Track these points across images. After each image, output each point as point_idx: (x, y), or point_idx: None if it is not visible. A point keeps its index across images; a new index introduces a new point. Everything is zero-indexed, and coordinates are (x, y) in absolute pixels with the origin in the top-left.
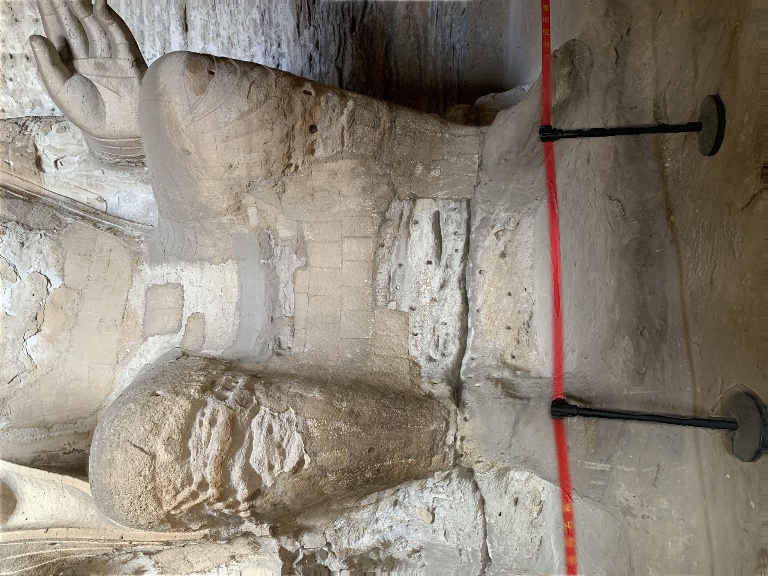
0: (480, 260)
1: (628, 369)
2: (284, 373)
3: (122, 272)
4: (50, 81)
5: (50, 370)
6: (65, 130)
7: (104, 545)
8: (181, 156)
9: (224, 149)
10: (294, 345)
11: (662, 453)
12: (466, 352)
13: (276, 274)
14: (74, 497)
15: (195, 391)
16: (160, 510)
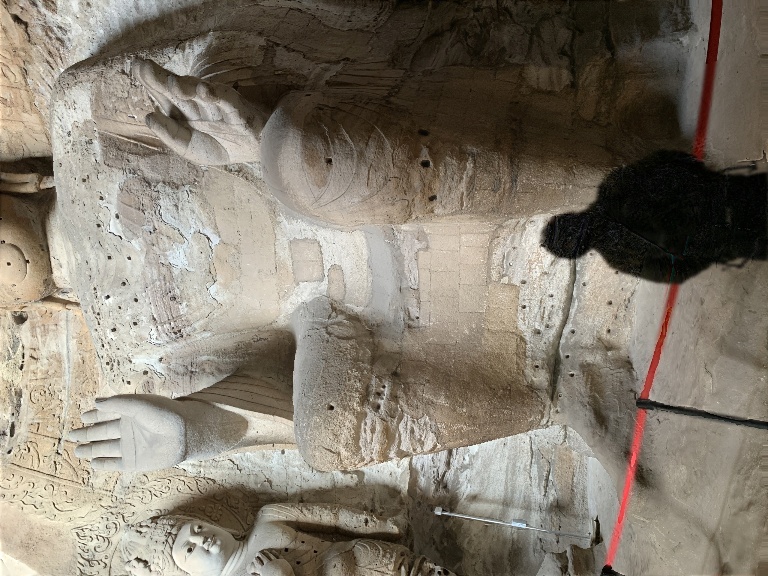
0: (592, 247)
1: (678, 484)
2: (416, 361)
3: (264, 225)
4: (175, 149)
5: (232, 306)
6: None
7: None
8: None
9: (350, 216)
10: (421, 317)
11: (684, 541)
12: (567, 322)
13: (401, 253)
14: (283, 424)
15: (357, 405)
16: None
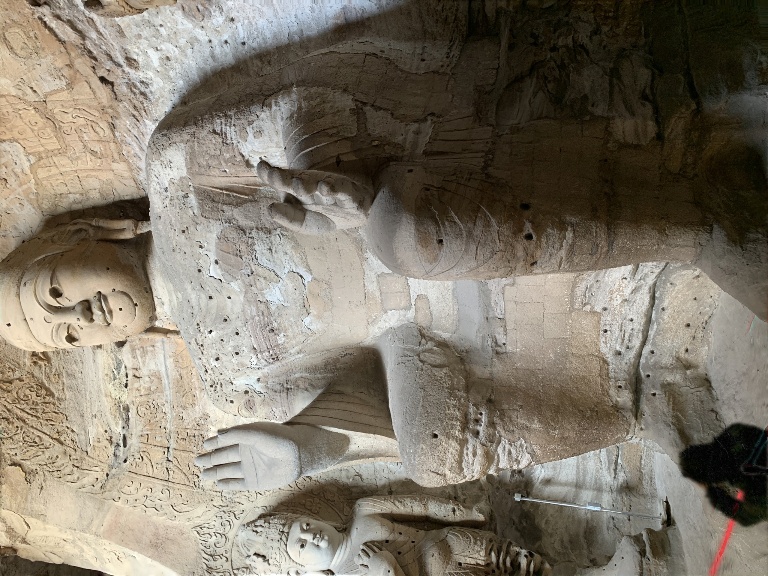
0: (673, 279)
1: (766, 509)
2: (508, 386)
3: (353, 262)
4: None
5: (324, 332)
6: (261, 135)
7: None
8: None
9: None
10: (508, 344)
11: None
12: (647, 343)
13: (488, 288)
14: (383, 440)
15: (459, 433)
16: None
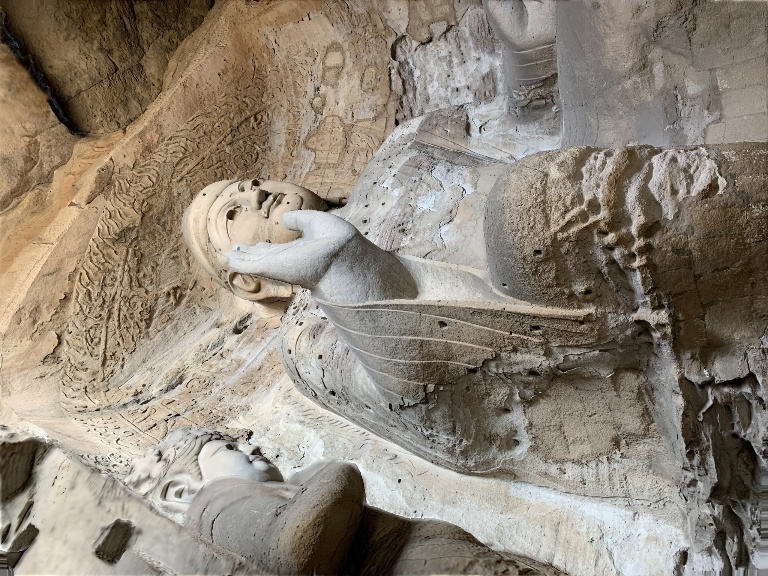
0: None
1: None
2: None
3: None
4: (490, 1)
5: (456, 251)
6: (491, 101)
7: (485, 337)
8: (591, 13)
9: None
10: None
11: None
12: None
13: (683, 134)
14: (465, 285)
15: None
16: (547, 231)
